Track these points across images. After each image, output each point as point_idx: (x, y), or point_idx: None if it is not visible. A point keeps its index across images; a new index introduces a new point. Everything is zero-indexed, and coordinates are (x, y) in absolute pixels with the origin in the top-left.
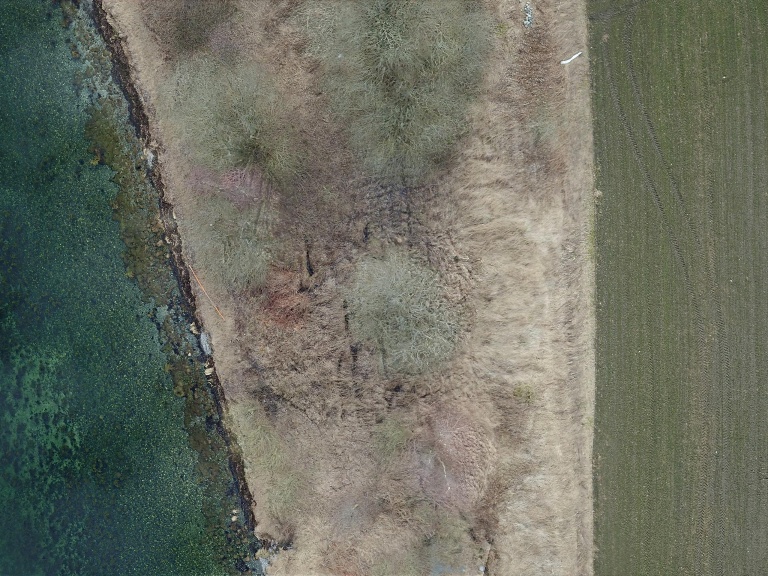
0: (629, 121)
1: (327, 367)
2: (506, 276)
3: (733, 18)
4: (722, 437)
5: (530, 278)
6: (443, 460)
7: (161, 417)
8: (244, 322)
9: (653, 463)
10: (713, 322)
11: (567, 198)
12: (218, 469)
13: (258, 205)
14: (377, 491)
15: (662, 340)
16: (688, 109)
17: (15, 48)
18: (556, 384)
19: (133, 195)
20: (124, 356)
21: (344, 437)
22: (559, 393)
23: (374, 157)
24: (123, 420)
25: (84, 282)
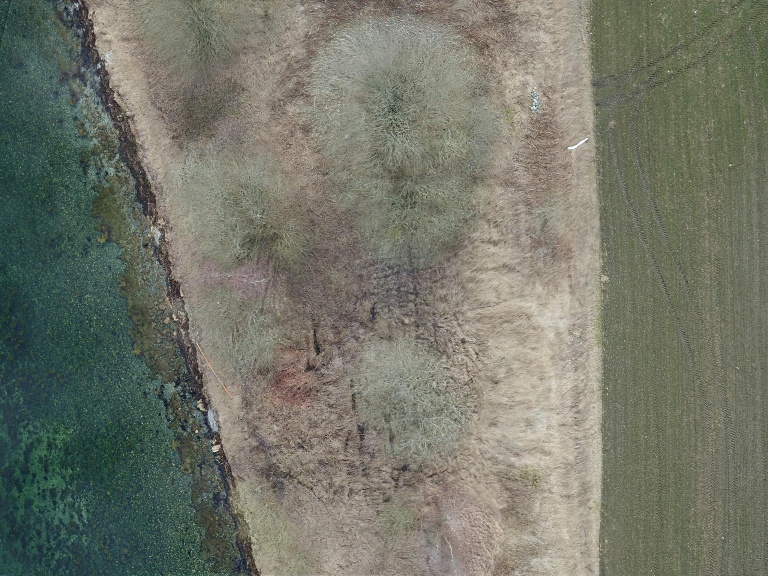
0: (636, 207)
1: (334, 446)
2: (513, 359)
3: (739, 106)
4: (728, 522)
5: (537, 362)
6: (450, 540)
7: (168, 493)
8: (251, 400)
9: (660, 547)
10: (719, 408)
11: (574, 283)
12: (225, 545)
13: (265, 284)
14: (384, 569)
15: (668, 425)
16: (694, 196)
17: (22, 125)
18: (563, 468)
19: (140, 272)
20: (131, 432)
21: (351, 515)
22: (566, 477)
23: (381, 238)
24: (130, 496)
25: (91, 358)
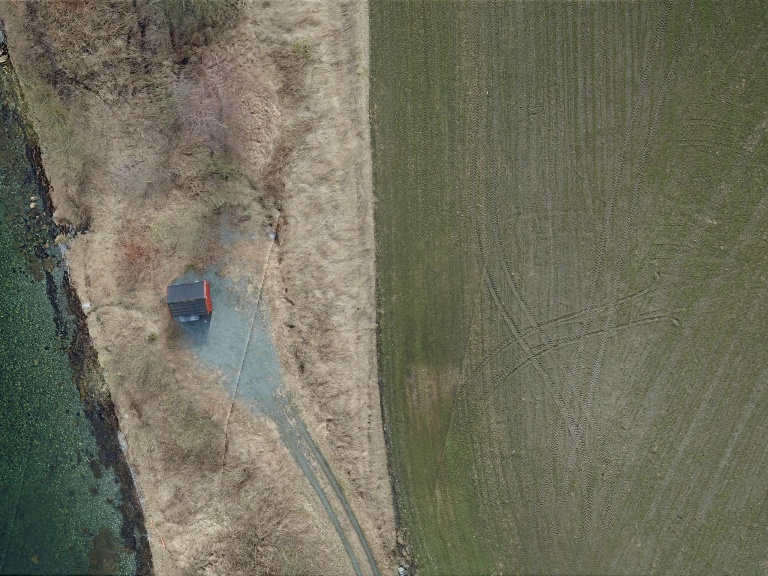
0: None
1: (117, 45)
2: None
3: None
4: (492, 77)
5: None
6: (231, 130)
7: None
8: (35, 6)
9: (427, 109)
10: None
11: None
12: (15, 157)
13: None
14: (170, 167)
15: None
16: None
17: None
18: (331, 35)
19: None
20: None
21: (136, 115)
22: (334, 44)
23: None
24: None
25: None
